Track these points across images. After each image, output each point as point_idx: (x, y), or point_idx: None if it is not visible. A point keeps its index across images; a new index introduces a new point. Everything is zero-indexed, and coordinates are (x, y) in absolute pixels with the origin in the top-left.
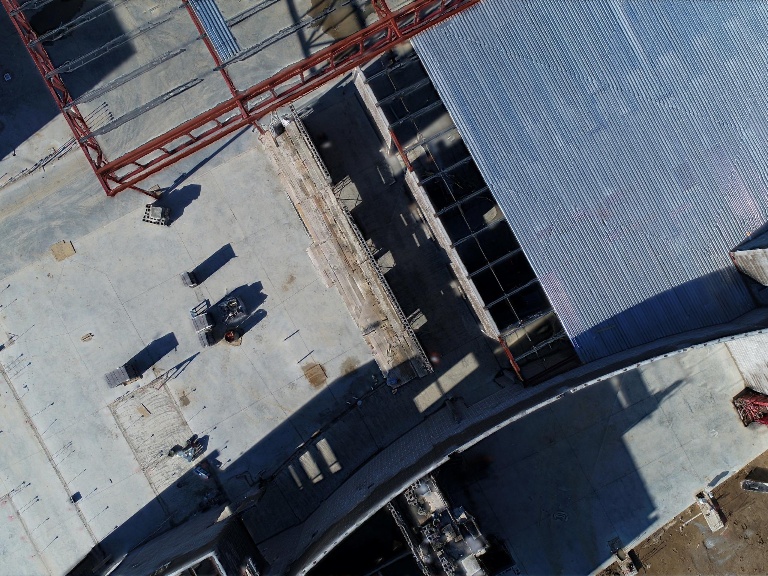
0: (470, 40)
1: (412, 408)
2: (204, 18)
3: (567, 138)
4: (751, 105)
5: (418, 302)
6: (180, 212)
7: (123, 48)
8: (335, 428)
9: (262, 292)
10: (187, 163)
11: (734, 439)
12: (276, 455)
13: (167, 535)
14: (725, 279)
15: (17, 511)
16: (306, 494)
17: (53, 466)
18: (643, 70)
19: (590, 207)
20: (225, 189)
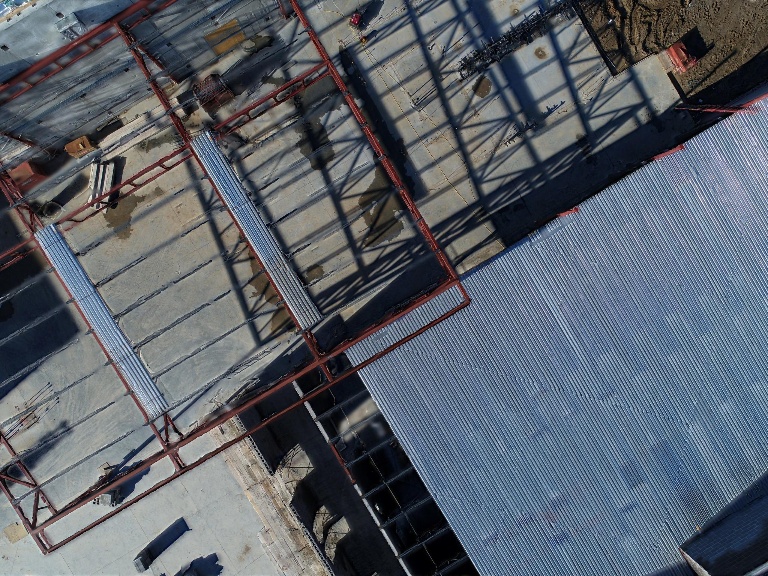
0: (407, 350)
1: None
2: (130, 377)
3: (510, 442)
4: (696, 398)
5: (375, 566)
6: (131, 488)
7: (64, 327)
8: None
9: (218, 564)
10: (135, 439)
11: None
12: None
13: None
14: (676, 574)
15: None
16: None
17: None
18: (585, 369)
19: (536, 510)
20: None
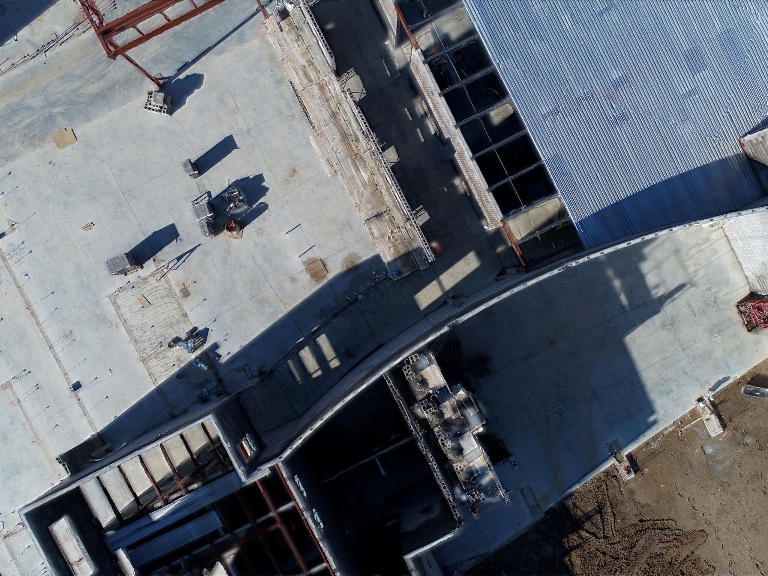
0: None
1: (413, 305)
2: None
3: (577, 17)
4: None
5: (421, 198)
6: (182, 102)
7: None
8: (335, 323)
9: (264, 185)
10: (190, 52)
11: (737, 344)
12: (275, 349)
13: (166, 424)
14: (734, 166)
15: (17, 398)
16: (305, 389)
17: (53, 355)
18: None
19: (598, 89)
20: (228, 79)
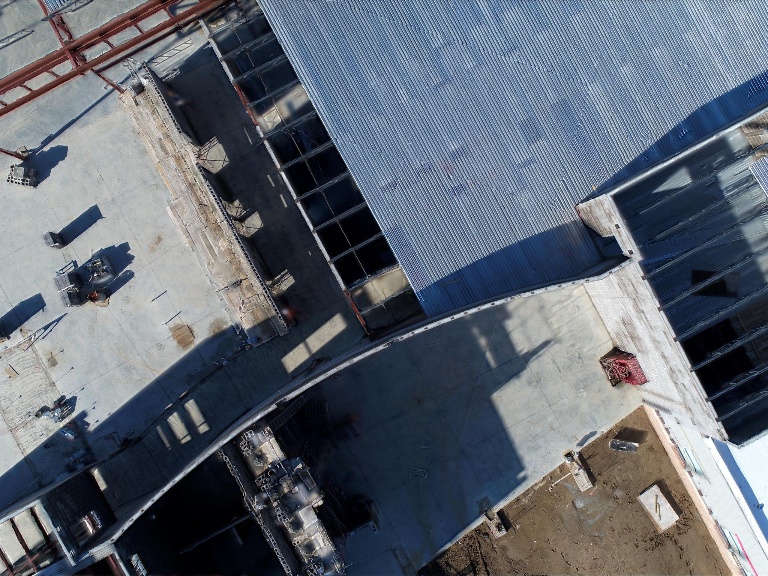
0: None
1: (280, 369)
2: None
3: (412, 92)
4: (597, 59)
5: (286, 263)
6: (47, 173)
7: None
8: (203, 389)
9: (129, 253)
10: (54, 124)
11: (602, 399)
12: (144, 416)
13: (32, 495)
14: (571, 233)
15: None
16: (174, 455)
17: None
18: (488, 24)
19: (435, 161)
20: (92, 150)
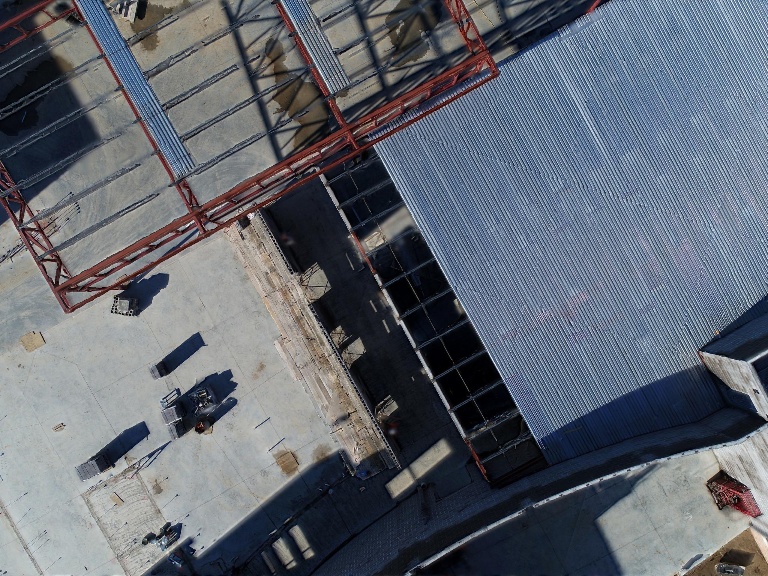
0: (432, 140)
1: (384, 494)
2: (158, 134)
3: (532, 238)
4: (721, 201)
5: (389, 388)
6: (149, 301)
7: (88, 137)
8: (307, 515)
9: (232, 380)
10: (155, 252)
11: (709, 522)
12: (249, 542)
13: None
14: (694, 378)
15: None
16: None
17: (28, 554)
18: (610, 167)
19: (556, 307)
20: (193, 278)
